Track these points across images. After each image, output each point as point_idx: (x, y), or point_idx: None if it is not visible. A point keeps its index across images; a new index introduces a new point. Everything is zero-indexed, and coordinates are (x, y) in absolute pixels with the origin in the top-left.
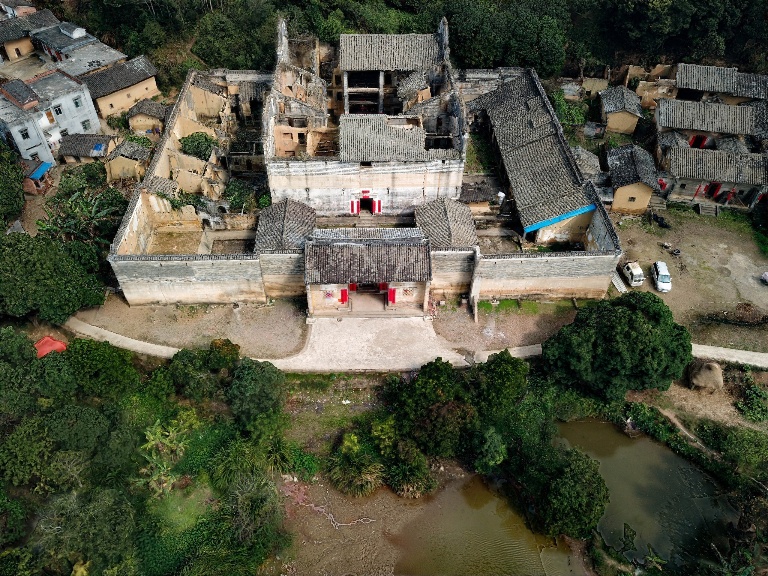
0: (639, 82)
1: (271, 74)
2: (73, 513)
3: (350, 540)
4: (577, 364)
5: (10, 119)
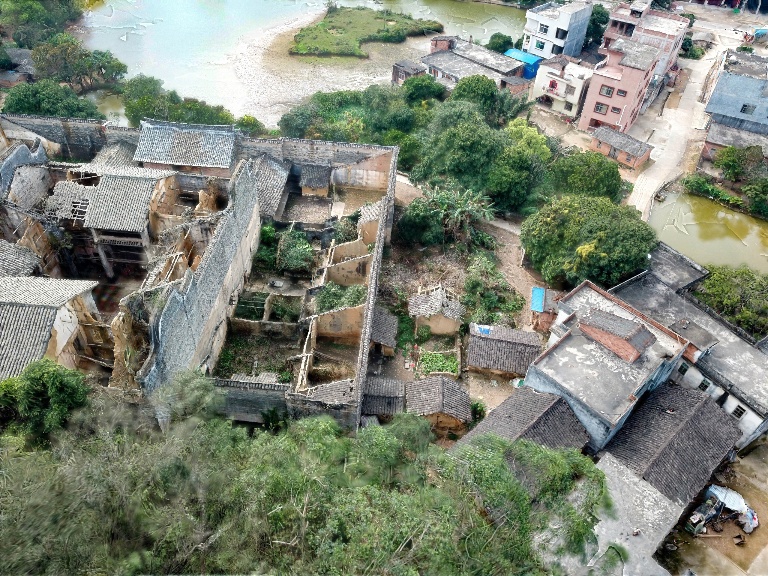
0: None
1: None
2: (387, 92)
3: (261, 115)
4: (93, 104)
5: (596, 300)
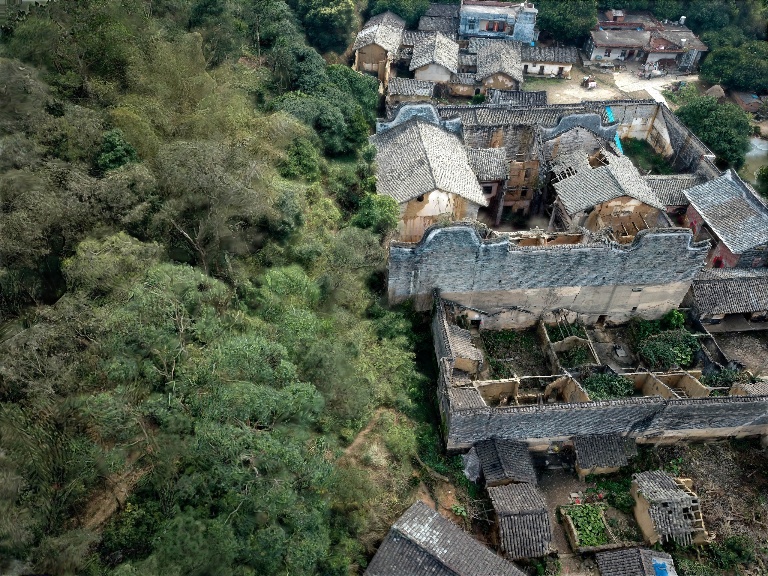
0: (386, 69)
1: None
2: None
3: None
4: None
5: None
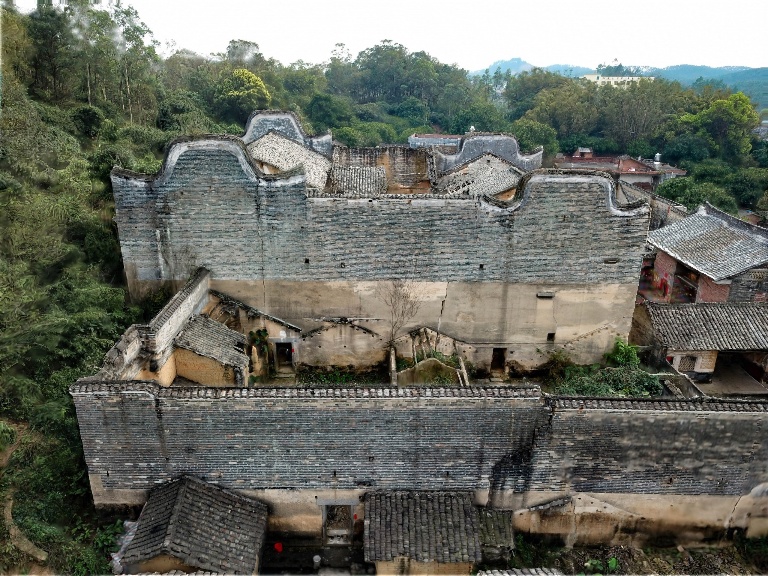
0: None
1: (197, 285)
2: None
3: None
4: None
5: None
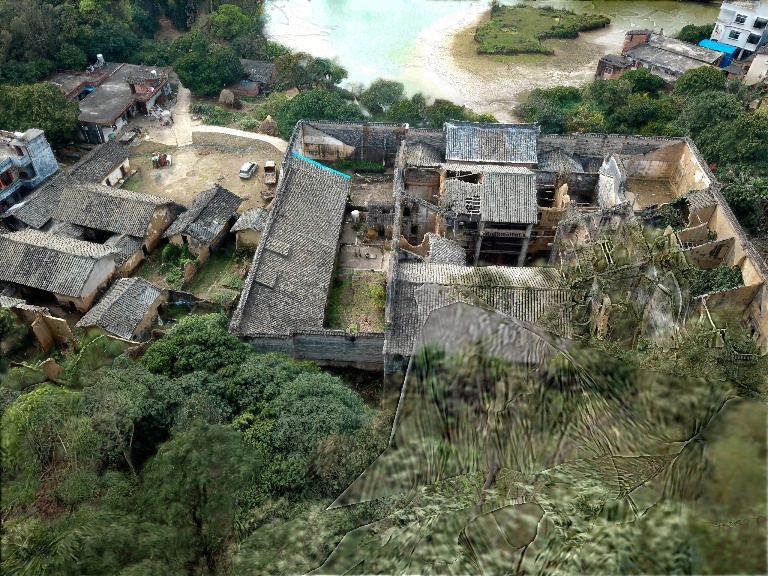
0: None
1: None
2: (616, 86)
3: (485, 113)
4: None
5: None
